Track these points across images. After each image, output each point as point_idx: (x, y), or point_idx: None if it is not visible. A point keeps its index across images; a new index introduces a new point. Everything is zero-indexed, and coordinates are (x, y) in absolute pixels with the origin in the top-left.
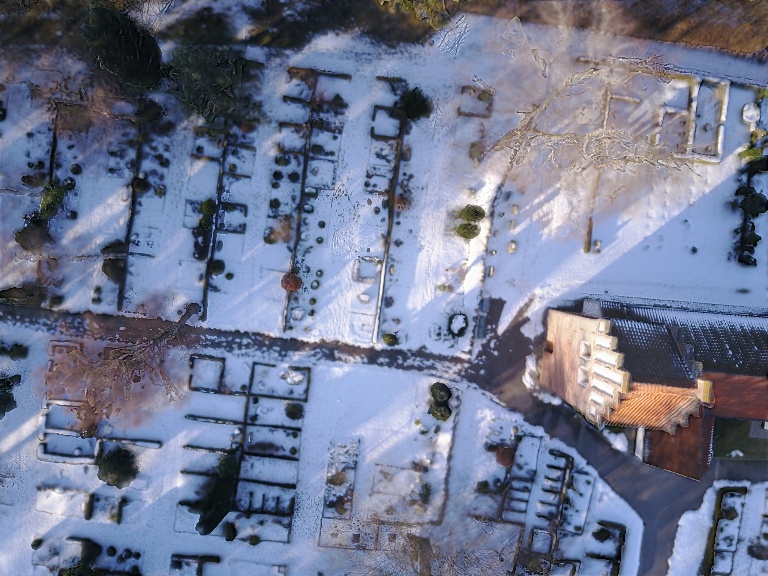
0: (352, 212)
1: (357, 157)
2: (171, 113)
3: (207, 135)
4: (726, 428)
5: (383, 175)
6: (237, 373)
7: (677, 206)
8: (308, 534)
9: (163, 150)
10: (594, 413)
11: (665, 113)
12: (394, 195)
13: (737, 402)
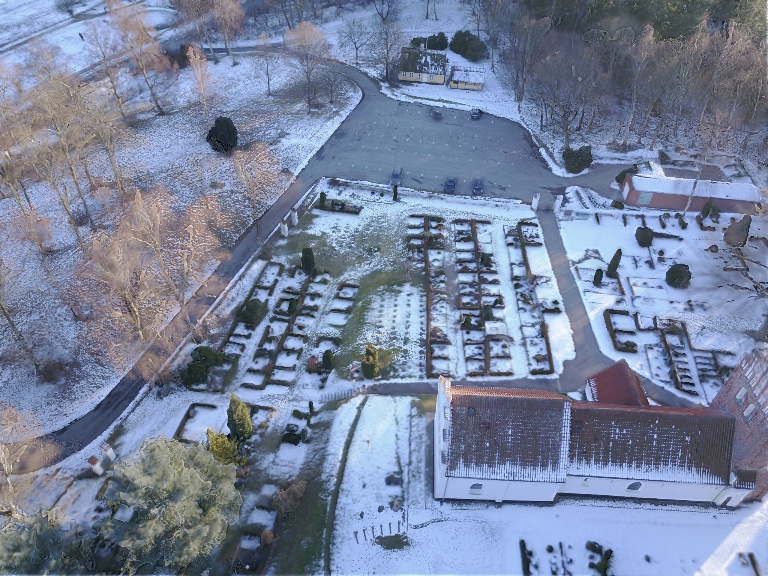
0: None
1: None
2: None
3: None
4: None
5: None
6: None
7: None
8: None
9: None
10: None
11: None
12: None
13: None
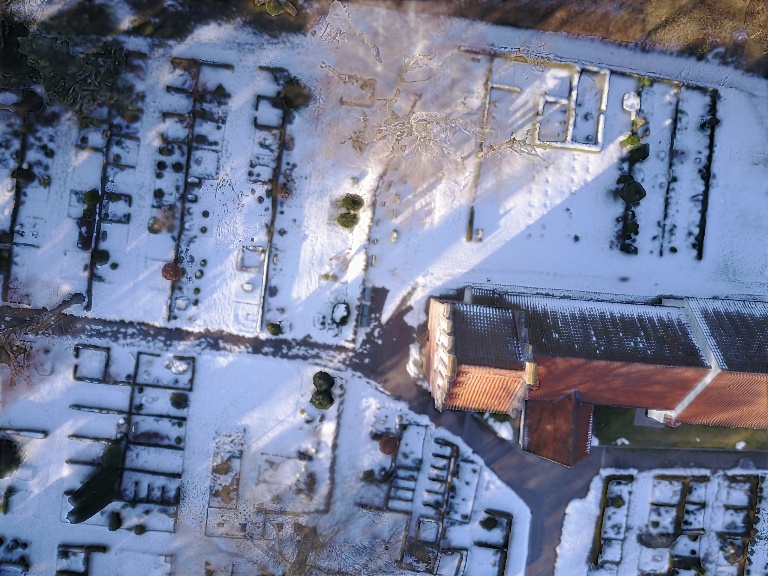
0: (236, 202)
1: (241, 147)
2: (55, 103)
3: (91, 125)
4: (610, 416)
5: (266, 165)
6: (122, 363)
7: (559, 195)
8: (194, 524)
9: (48, 140)
10: (438, 397)
11: (545, 102)
12: (277, 185)
13: (605, 388)
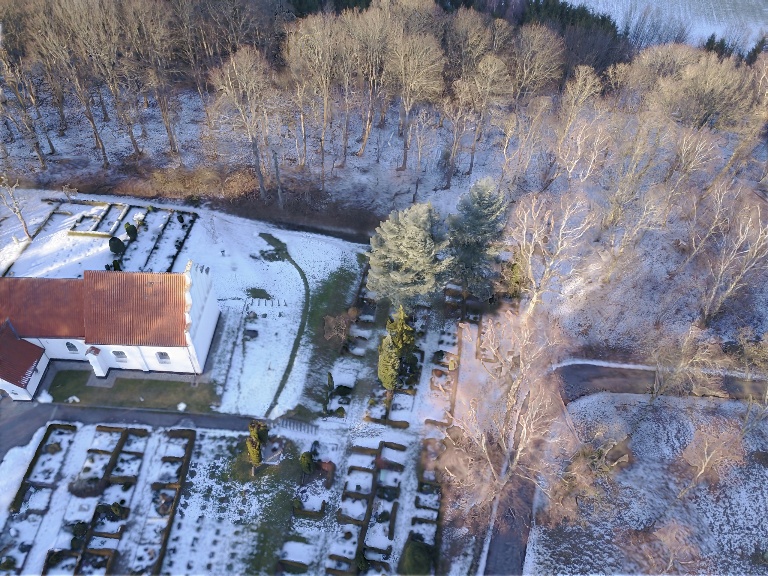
0: None
1: None
2: None
3: None
4: (68, 379)
5: None
6: None
7: (76, 257)
8: None
9: None
10: None
11: (83, 217)
12: None
13: (27, 314)
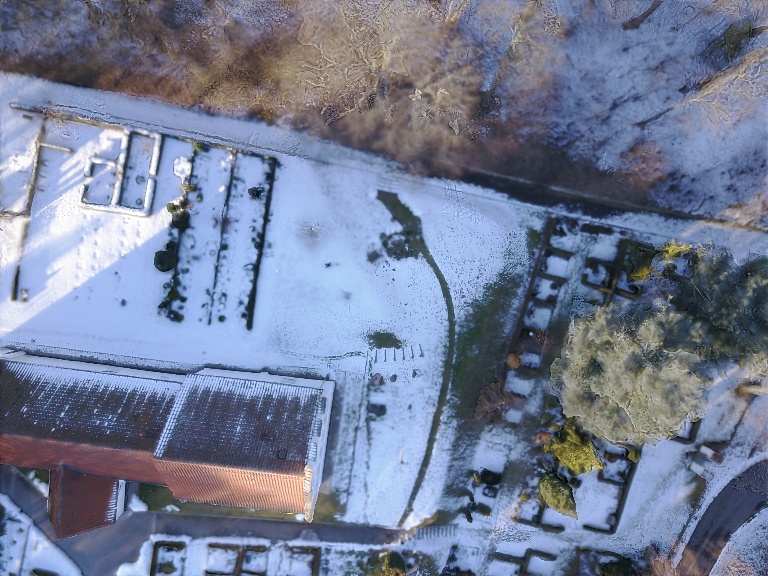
0: None
1: None
2: None
3: None
4: None
5: None
6: None
7: (108, 258)
8: None
9: None
10: None
11: (92, 164)
12: None
13: (86, 463)
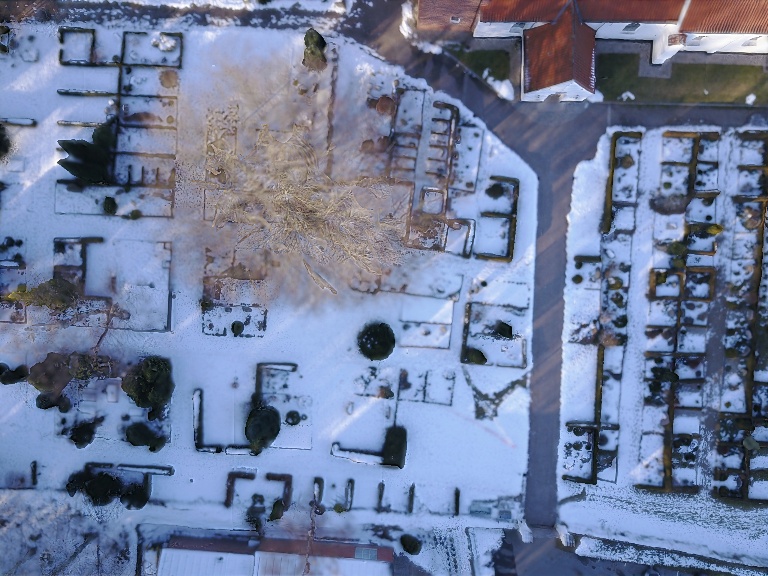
0: None
1: None
2: None
3: None
4: (614, 68)
5: None
6: (108, 45)
7: None
8: (192, 208)
9: None
10: None
11: None
12: None
13: None
